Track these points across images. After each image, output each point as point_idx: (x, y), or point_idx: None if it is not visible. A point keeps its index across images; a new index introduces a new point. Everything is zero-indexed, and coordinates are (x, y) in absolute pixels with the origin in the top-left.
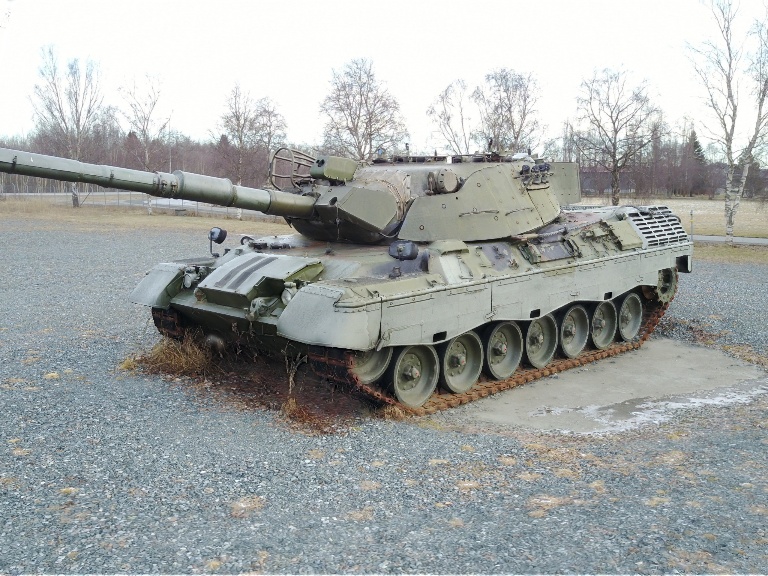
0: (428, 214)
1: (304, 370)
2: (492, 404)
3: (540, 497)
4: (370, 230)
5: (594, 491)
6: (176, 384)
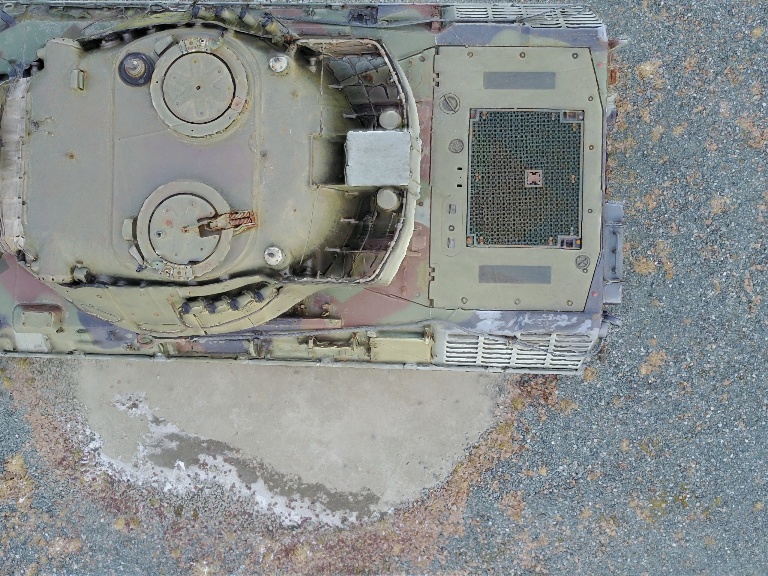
0: None
1: None
2: None
3: None
4: None
5: None
6: None
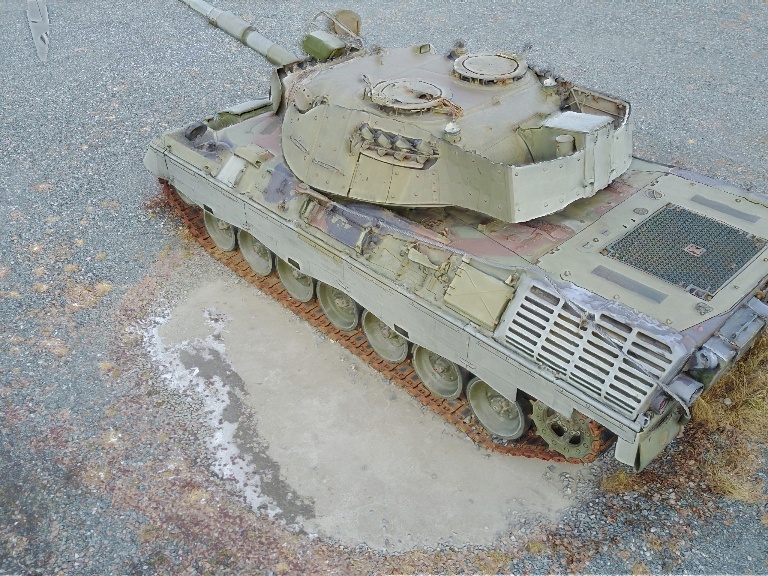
0: None
1: None
2: (242, 291)
3: (5, 269)
4: None
5: (2, 290)
6: None
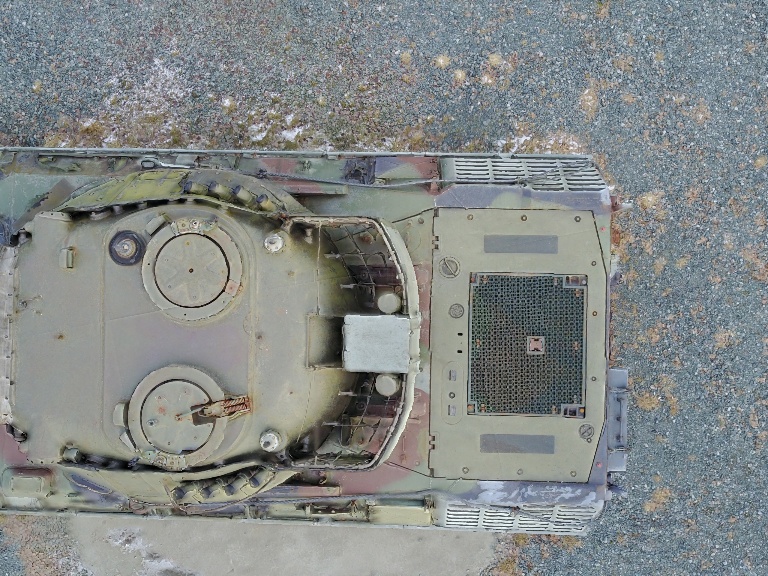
0: None
1: None
2: None
3: None
4: None
5: None
6: None
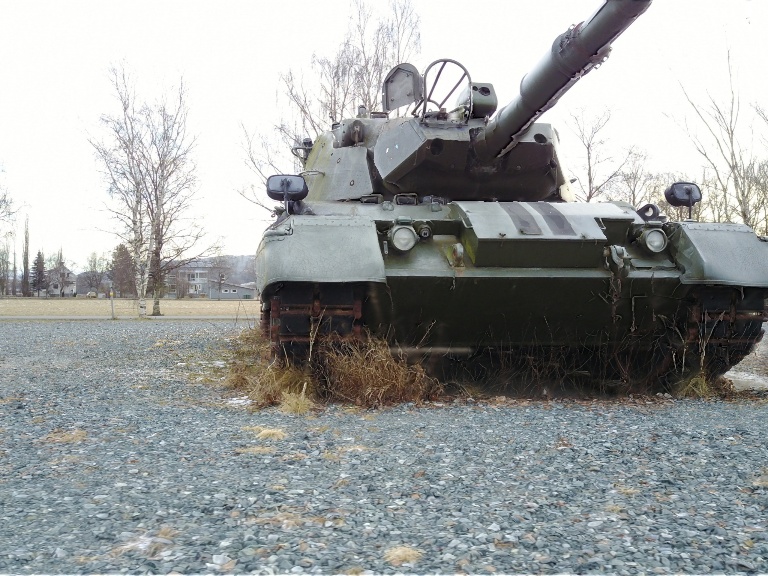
0: None
1: (477, 380)
2: None
3: None
4: (555, 182)
5: None
6: (469, 407)
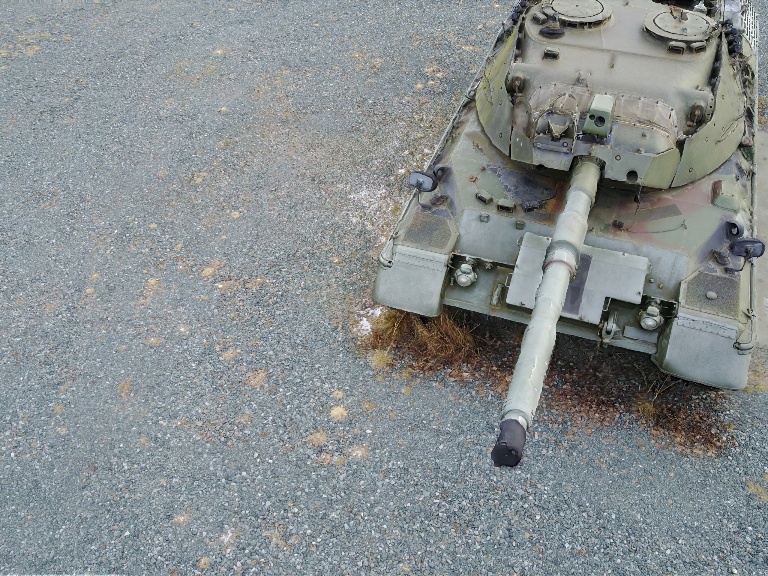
0: (696, 154)
1: None
2: None
3: None
4: (654, 191)
5: None
6: (478, 387)
